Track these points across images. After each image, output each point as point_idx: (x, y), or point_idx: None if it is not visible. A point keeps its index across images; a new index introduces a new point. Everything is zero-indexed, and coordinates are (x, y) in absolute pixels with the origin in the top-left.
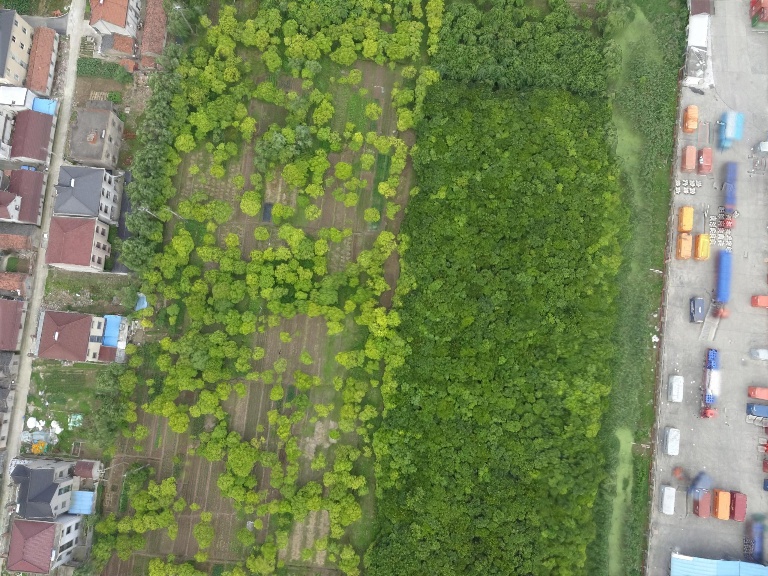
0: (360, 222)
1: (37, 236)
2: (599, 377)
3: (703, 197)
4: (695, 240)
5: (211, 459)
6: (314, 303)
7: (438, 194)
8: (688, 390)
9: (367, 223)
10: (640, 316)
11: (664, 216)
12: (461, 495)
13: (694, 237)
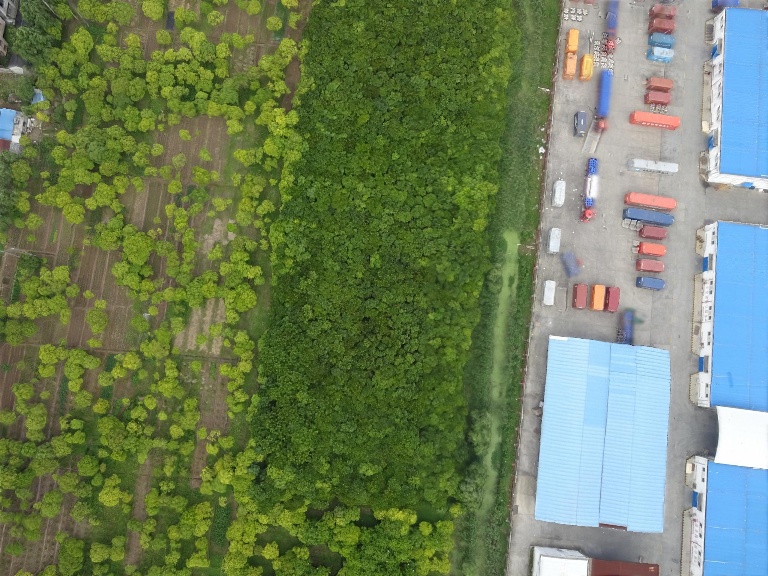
0: (263, 33)
1: None
2: (487, 176)
3: (589, 24)
4: (580, 61)
5: (106, 247)
6: (214, 102)
7: (338, 2)
8: (571, 197)
9: (270, 35)
10: (528, 127)
11: (553, 39)
12: (352, 278)
13: (580, 59)
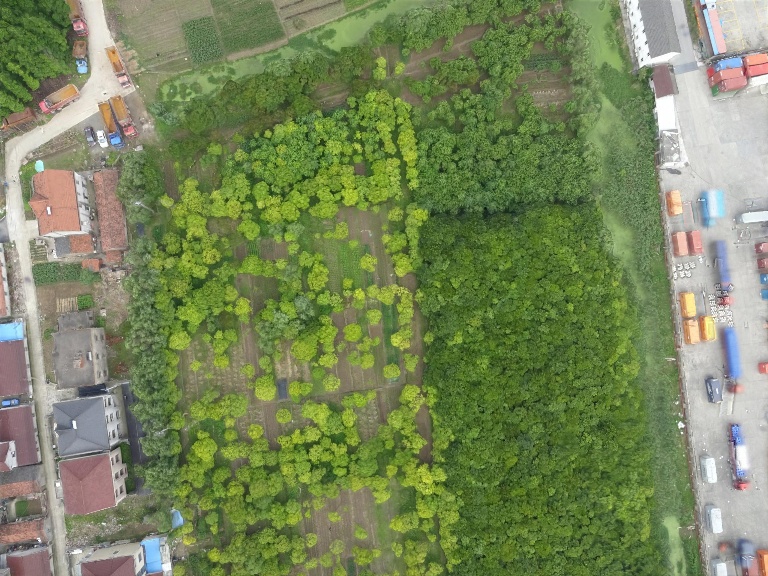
0: (379, 377)
1: (42, 474)
2: (642, 482)
3: (699, 277)
4: (700, 322)
5: None
6: (356, 477)
7: (455, 340)
8: (718, 466)
9: None
10: (664, 409)
11: (667, 305)
12: None
13: (698, 319)
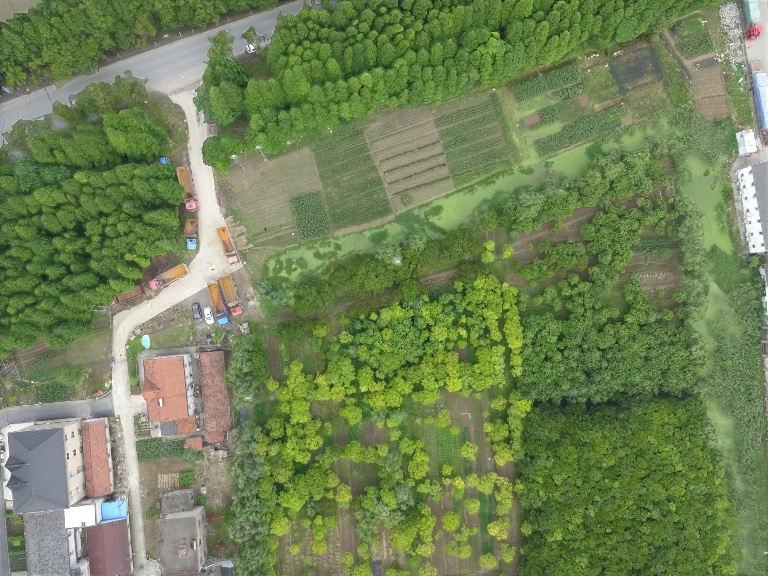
0: (473, 562)
1: None
2: None
3: None
4: None
5: None
6: None
7: (554, 536)
8: None
9: None
10: None
11: (767, 498)
12: None
13: None
